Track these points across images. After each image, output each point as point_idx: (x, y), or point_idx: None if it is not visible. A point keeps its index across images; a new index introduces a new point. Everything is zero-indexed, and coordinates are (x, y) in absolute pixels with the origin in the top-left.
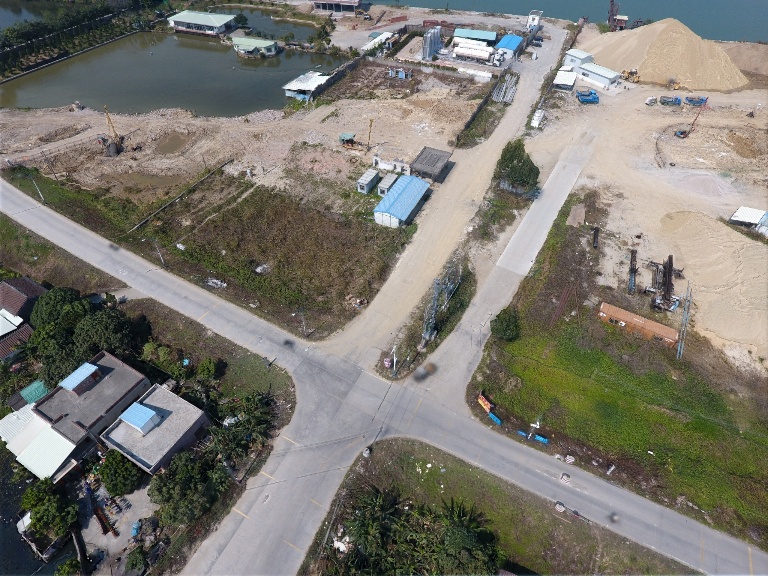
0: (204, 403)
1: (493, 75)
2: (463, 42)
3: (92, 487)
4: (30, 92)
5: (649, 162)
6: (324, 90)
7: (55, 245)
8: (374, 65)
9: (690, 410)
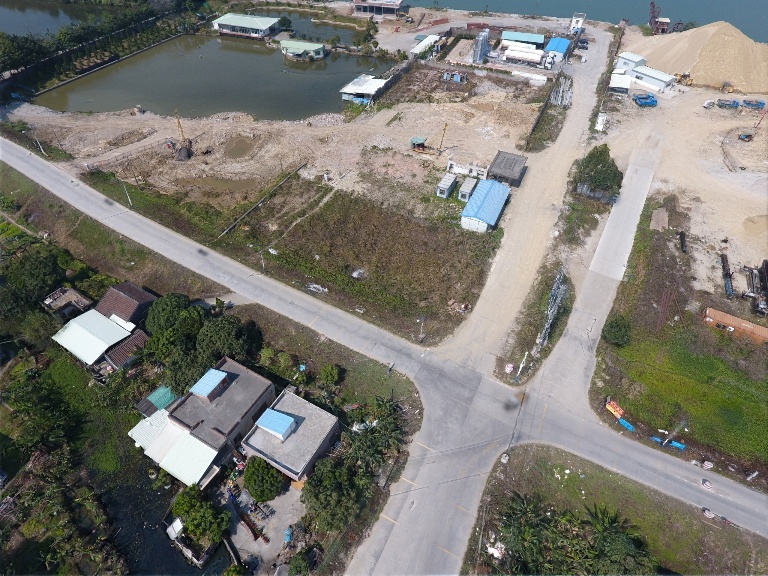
0: (335, 409)
1: (547, 78)
2: (512, 45)
3: (233, 493)
4: (84, 95)
5: (719, 166)
6: (382, 93)
7: (151, 250)
8: (426, 68)
9: None
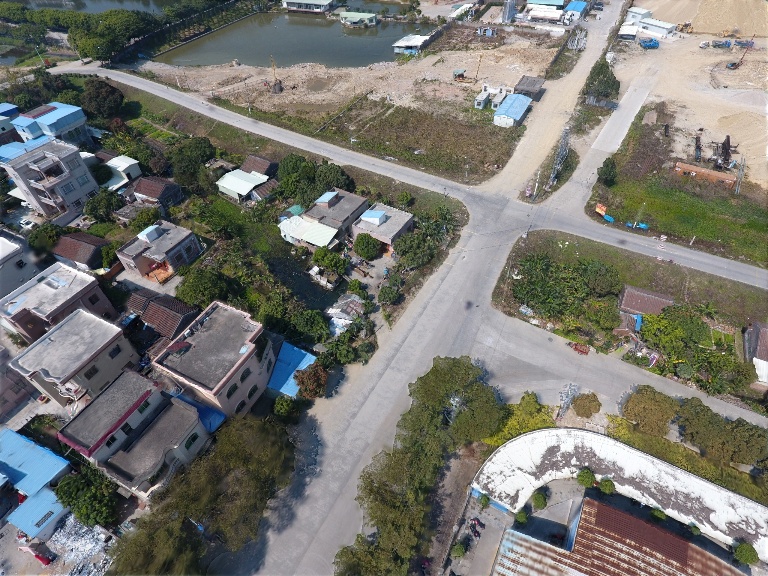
0: None
1: (565, 30)
2: (536, 7)
3: None
4: (187, 58)
5: (705, 85)
6: (427, 45)
7: (270, 139)
8: (463, 27)
9: None
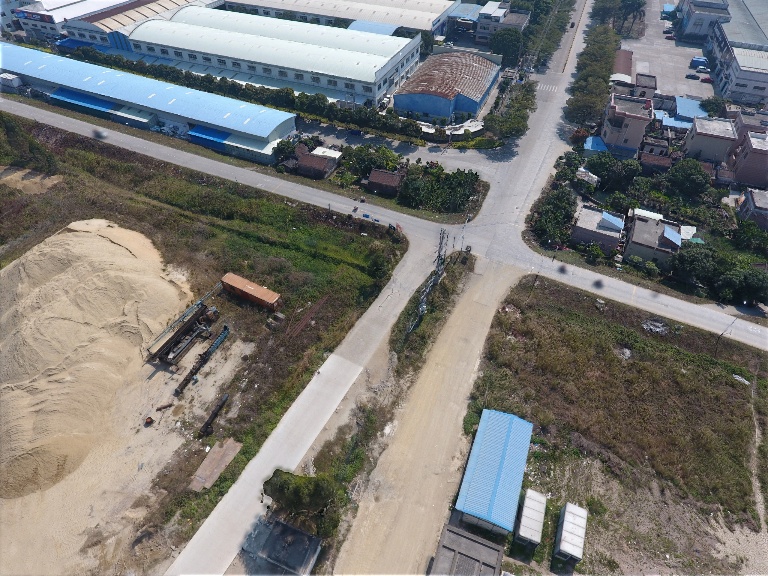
0: None
1: None
2: None
3: None
4: None
5: None
6: None
7: None
8: None
9: (253, 242)
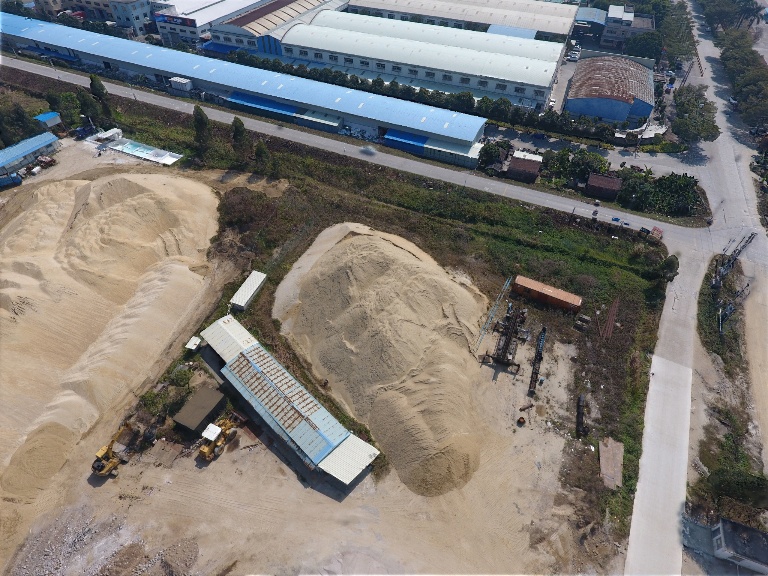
0: None
1: None
2: None
3: None
4: None
5: None
6: None
7: None
8: None
9: None
